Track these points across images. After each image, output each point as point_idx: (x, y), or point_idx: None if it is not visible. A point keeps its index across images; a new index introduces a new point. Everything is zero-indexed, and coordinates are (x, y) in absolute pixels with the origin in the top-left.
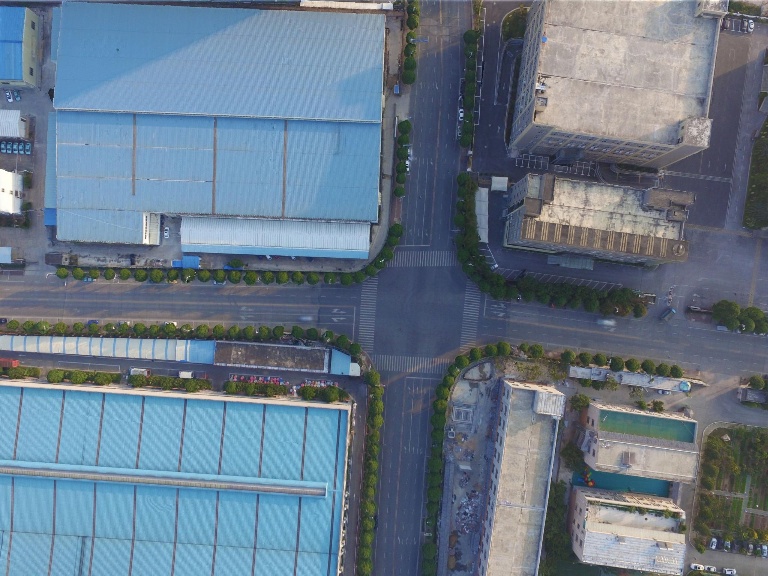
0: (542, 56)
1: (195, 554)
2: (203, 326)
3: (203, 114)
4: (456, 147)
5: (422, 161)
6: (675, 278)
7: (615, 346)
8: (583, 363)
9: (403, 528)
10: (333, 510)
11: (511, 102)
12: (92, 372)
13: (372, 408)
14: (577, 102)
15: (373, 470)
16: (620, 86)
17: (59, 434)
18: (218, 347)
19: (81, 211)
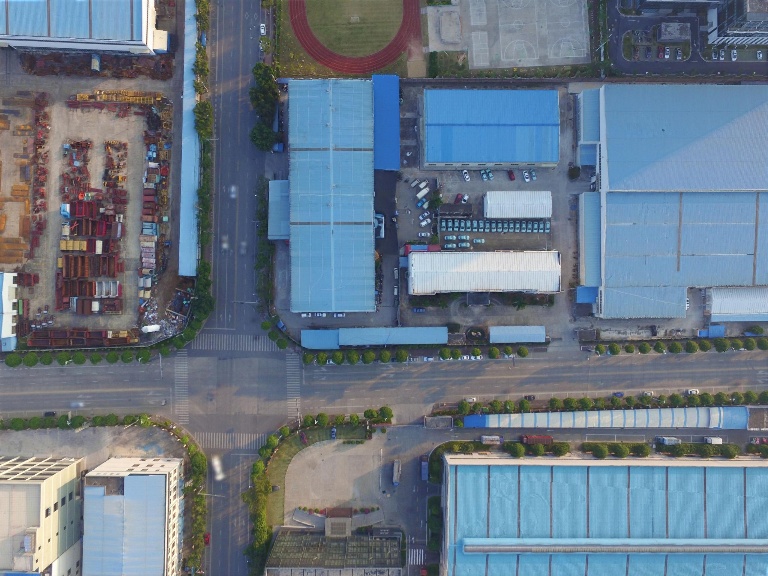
0: None
1: None
2: (740, 393)
3: (750, 190)
4: None
5: None
6: None
7: None
8: None
9: None
10: None
11: None
12: (627, 444)
13: None
14: None
15: None
16: None
17: (628, 509)
18: (751, 413)
19: (627, 289)
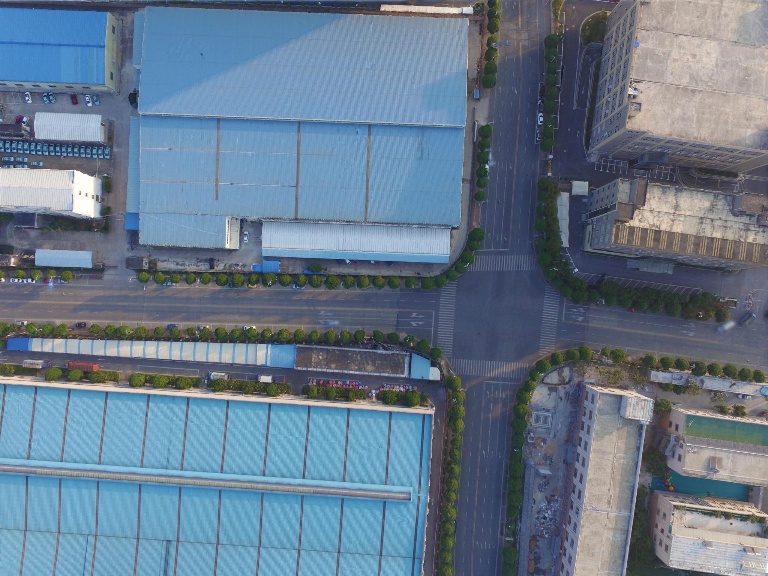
0: (634, 61)
1: (279, 558)
2: (284, 330)
3: (287, 119)
4: (535, 151)
5: (501, 165)
6: (755, 282)
7: (694, 350)
8: (663, 367)
9: (482, 532)
10: (417, 514)
11: (591, 106)
12: (172, 376)
13: (454, 412)
14: (669, 107)
15: (455, 474)
16: (712, 91)
17: (144, 438)
18: (299, 351)
19: (164, 216)
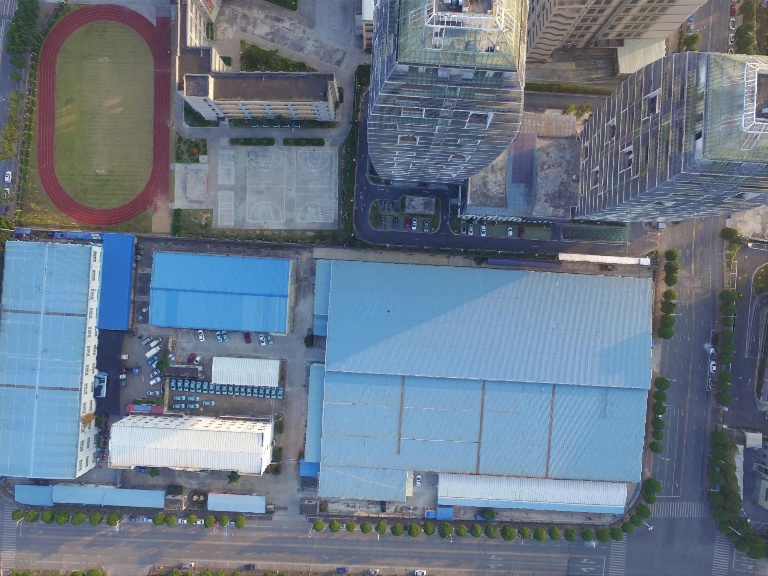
0: None
1: None
2: None
3: (474, 378)
4: (707, 398)
5: (673, 412)
6: None
7: None
8: None
9: None
10: None
11: (764, 357)
12: None
13: None
14: None
15: None
16: None
17: None
18: None
19: (345, 469)
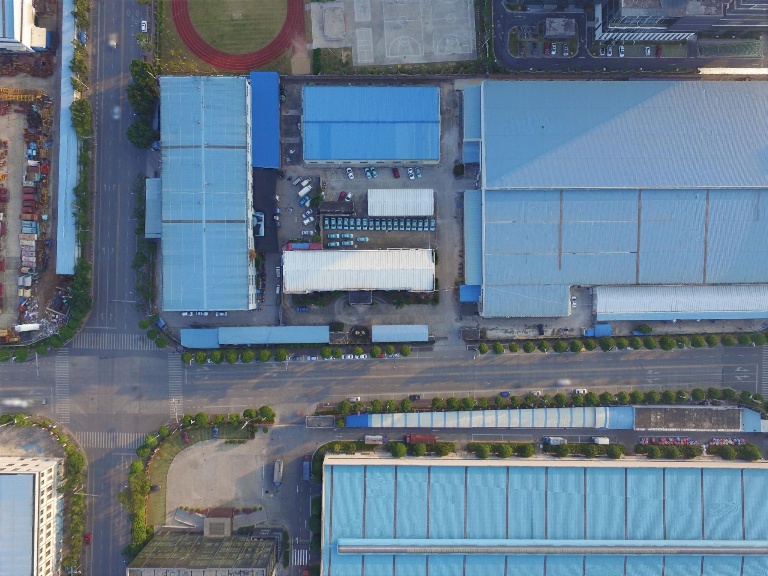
0: None
1: None
2: (625, 393)
3: (631, 187)
4: None
5: None
6: None
7: None
8: None
9: None
10: None
11: None
12: (512, 444)
13: None
14: None
15: None
16: None
17: (506, 510)
18: (638, 412)
19: (508, 287)
